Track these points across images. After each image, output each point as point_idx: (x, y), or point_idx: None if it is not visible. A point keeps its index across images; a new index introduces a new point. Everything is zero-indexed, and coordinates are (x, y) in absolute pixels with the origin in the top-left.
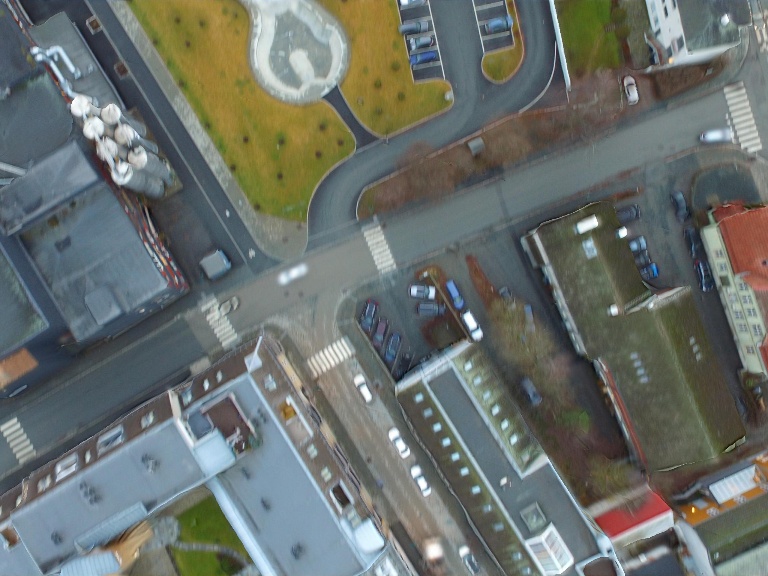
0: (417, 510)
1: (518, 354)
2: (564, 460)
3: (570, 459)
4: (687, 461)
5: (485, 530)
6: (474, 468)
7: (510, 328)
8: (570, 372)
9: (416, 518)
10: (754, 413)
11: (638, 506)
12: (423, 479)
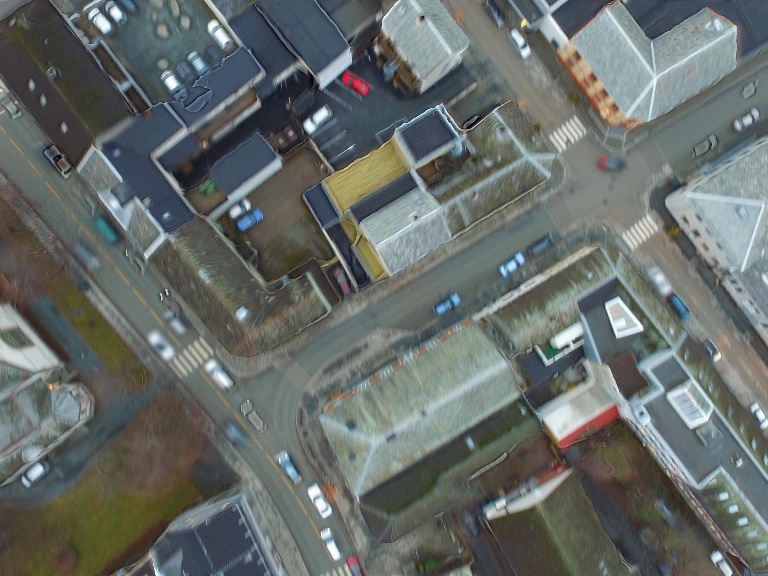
0: (759, 387)
1: (678, 544)
2: (635, 456)
3: (633, 460)
4: (557, 495)
5: (736, 403)
6: (765, 469)
7: (687, 567)
8: (624, 531)
9: (760, 379)
10: (459, 525)
11: (582, 435)
12: (761, 419)
